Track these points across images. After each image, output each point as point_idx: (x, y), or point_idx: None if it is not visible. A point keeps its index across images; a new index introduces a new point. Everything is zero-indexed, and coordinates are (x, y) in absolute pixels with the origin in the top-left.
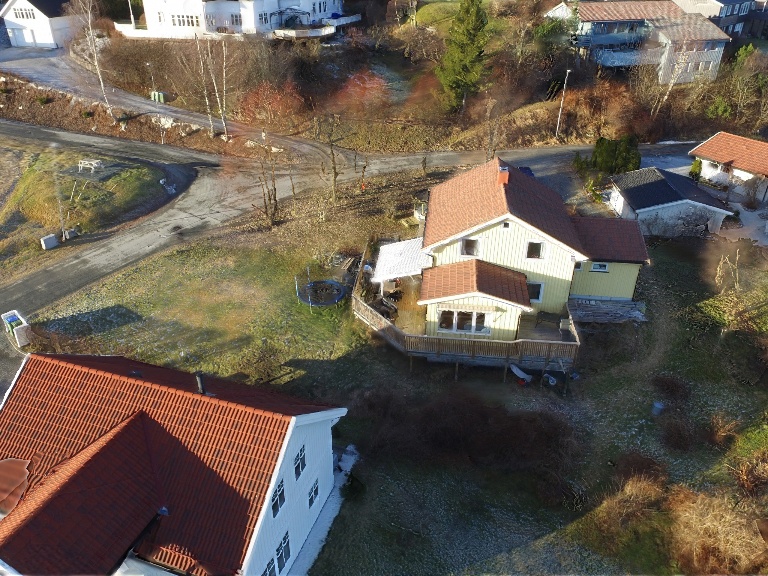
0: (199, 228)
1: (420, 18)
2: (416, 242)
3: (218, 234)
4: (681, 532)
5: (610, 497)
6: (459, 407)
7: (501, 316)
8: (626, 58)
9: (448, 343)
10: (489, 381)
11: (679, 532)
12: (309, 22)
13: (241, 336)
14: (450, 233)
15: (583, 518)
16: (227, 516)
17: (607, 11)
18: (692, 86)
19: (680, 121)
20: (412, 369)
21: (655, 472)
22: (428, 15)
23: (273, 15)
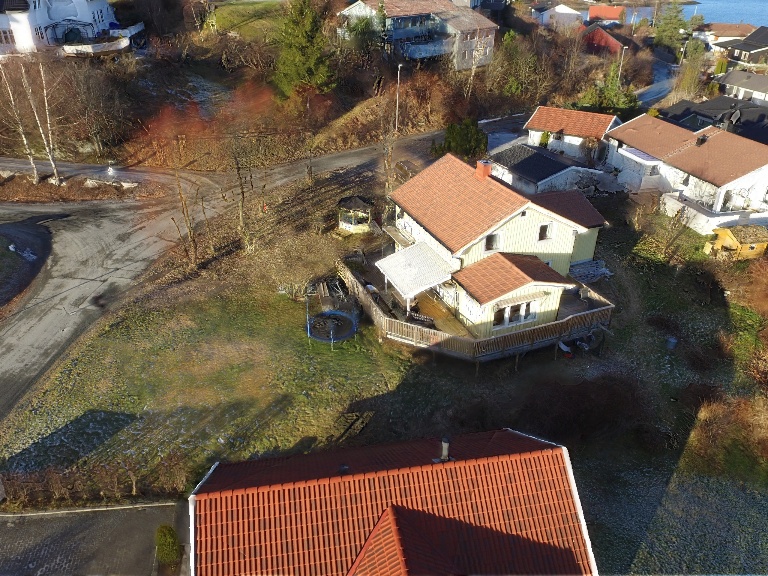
0: (109, 293)
1: (217, 23)
2: (413, 250)
3: (142, 294)
4: (758, 434)
5: (694, 427)
6: (554, 394)
7: (546, 299)
8: (429, 49)
9: (512, 338)
10: (542, 363)
11: (755, 434)
12: (94, 34)
13: (276, 398)
14: (476, 232)
15: (685, 452)
16: (558, 575)
17: (399, 7)
18: (489, 70)
19: (486, 101)
20: (474, 374)
21: (720, 393)
22: (224, 19)
23: (48, 29)
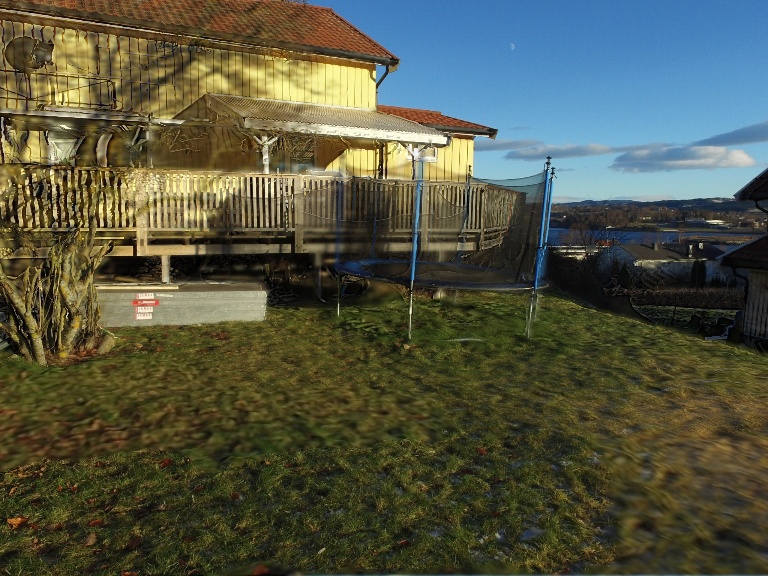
0: None
1: None
2: None
3: None
4: None
5: None
6: None
7: None
8: None
9: None
10: None
11: None
12: None
13: None
14: None
15: None
16: None
17: None
18: None
19: None
20: None
21: None
22: None
23: None
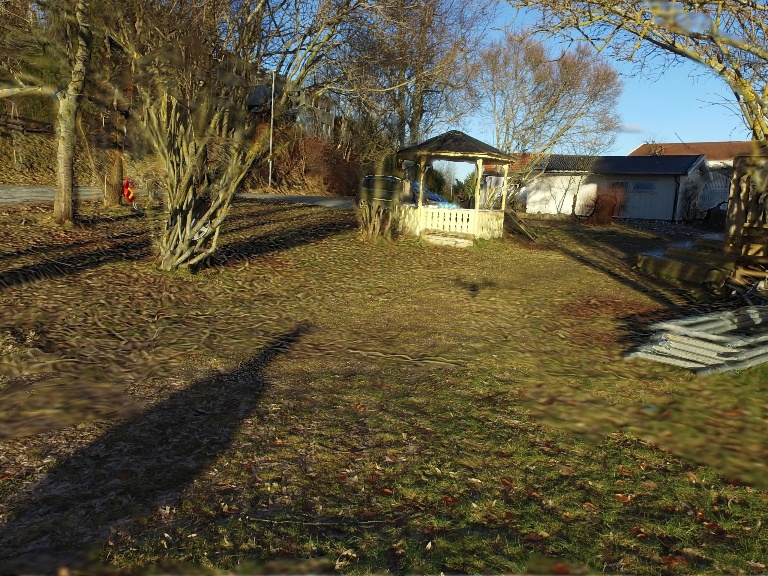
0: None
1: None
2: None
3: None
4: None
5: None
6: None
7: None
8: None
9: None
10: None
11: None
12: None
13: None
14: None
15: None
16: None
17: None
18: None
19: (363, 175)
20: None
21: None
22: None
23: None
